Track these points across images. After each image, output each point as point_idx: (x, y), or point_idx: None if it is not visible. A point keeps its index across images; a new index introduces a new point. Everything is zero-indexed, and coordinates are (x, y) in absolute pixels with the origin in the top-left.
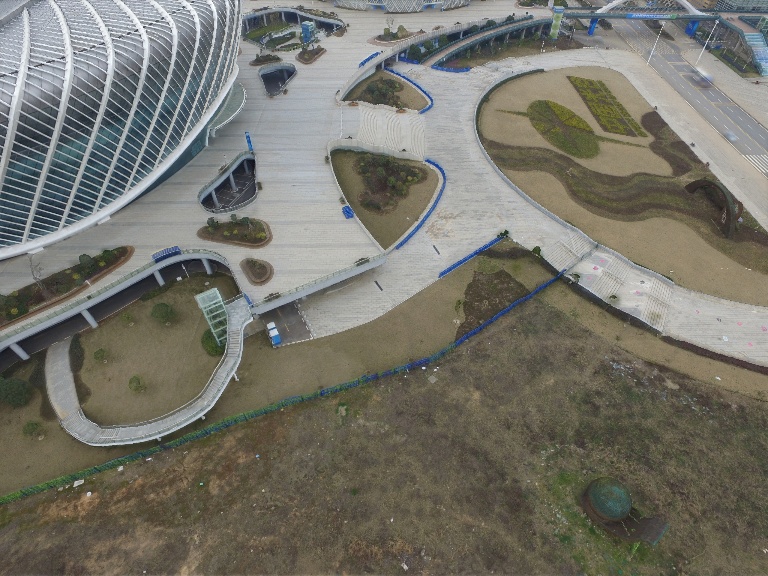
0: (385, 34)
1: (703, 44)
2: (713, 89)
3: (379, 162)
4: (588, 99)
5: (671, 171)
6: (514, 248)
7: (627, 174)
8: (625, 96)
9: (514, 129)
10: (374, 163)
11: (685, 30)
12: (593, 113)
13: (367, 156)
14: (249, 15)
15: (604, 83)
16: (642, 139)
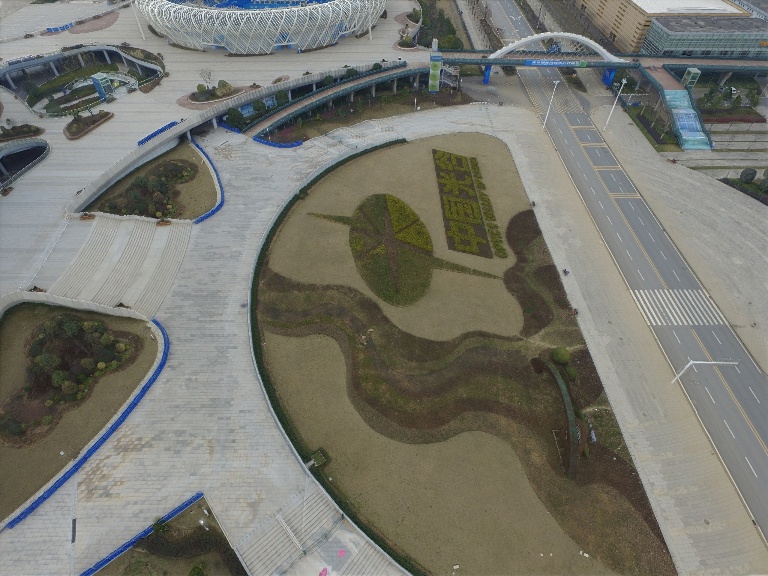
0: (199, 92)
1: (619, 99)
2: (617, 170)
3: (67, 333)
4: (446, 190)
5: (521, 326)
6: (201, 528)
7: (453, 336)
8: (499, 183)
9: (319, 250)
10: (59, 334)
11: (602, 78)
12: (444, 215)
13: (46, 325)
14: (53, 56)
15: (478, 161)
16: (498, 262)
